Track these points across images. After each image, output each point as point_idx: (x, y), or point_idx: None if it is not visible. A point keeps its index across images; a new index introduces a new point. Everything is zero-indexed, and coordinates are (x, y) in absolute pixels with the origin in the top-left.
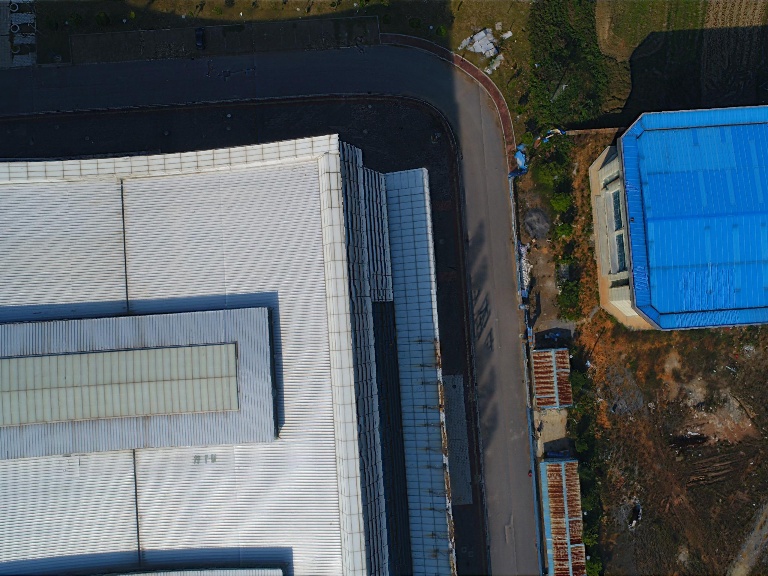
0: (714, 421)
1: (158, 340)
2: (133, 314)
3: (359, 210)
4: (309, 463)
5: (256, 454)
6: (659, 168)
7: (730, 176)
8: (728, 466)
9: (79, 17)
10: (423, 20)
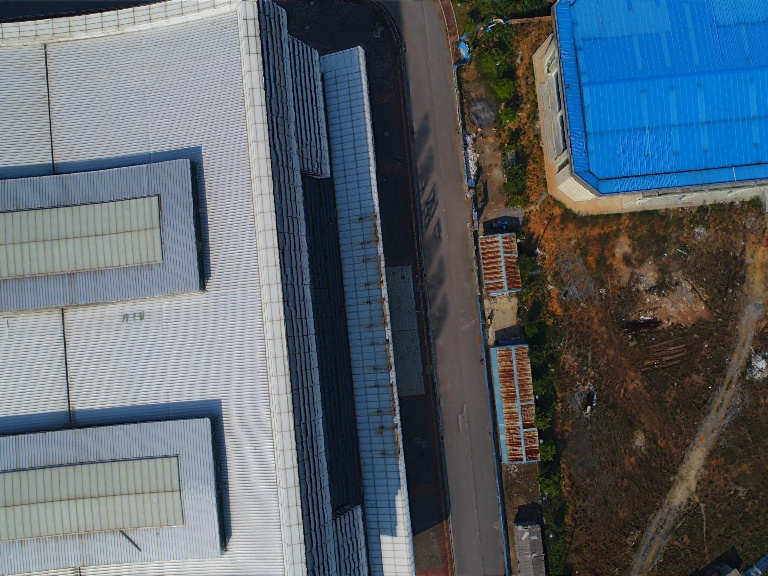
0: (667, 305)
1: (82, 197)
2: None
3: (283, 67)
4: (236, 314)
5: (184, 309)
6: (593, 34)
7: (665, 39)
8: (682, 349)
9: None
10: None
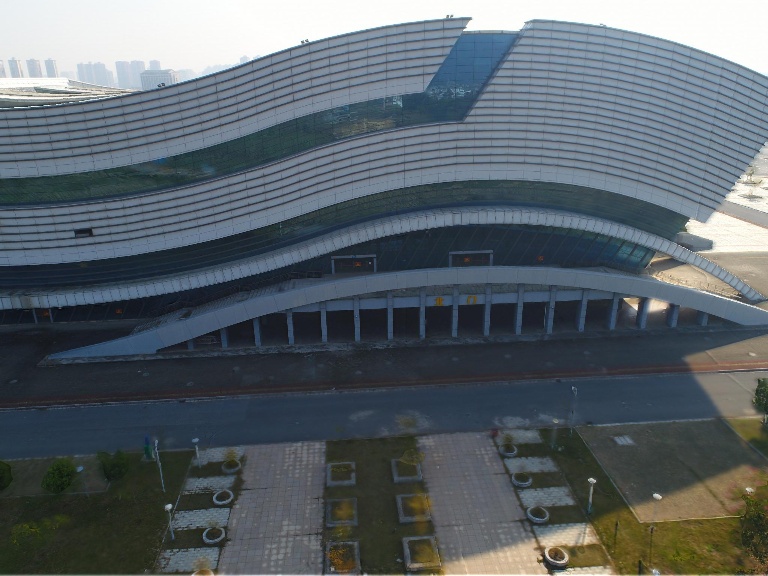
0: None
1: None
2: None
3: None
4: None
5: None
6: None
7: None
8: None
9: (45, 479)
10: None
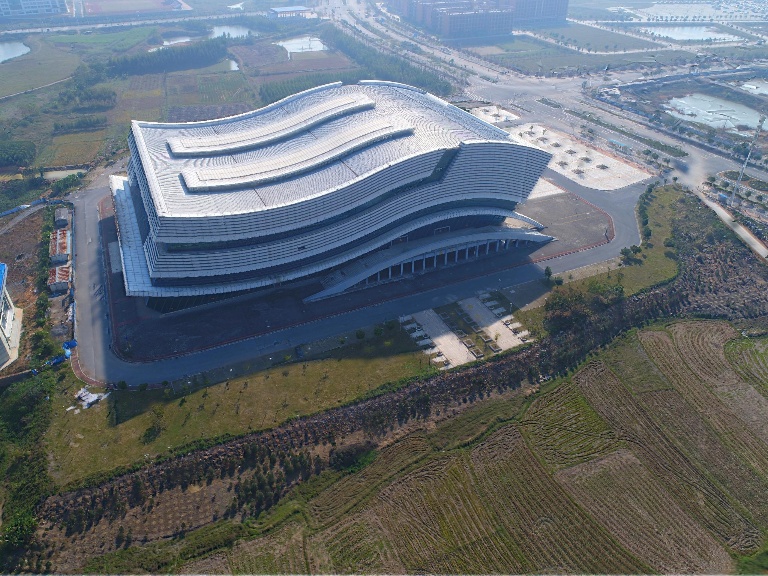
0: None
1: (234, 179)
2: (251, 187)
3: None
4: None
5: None
6: None
7: None
8: None
9: (376, 332)
10: (139, 400)
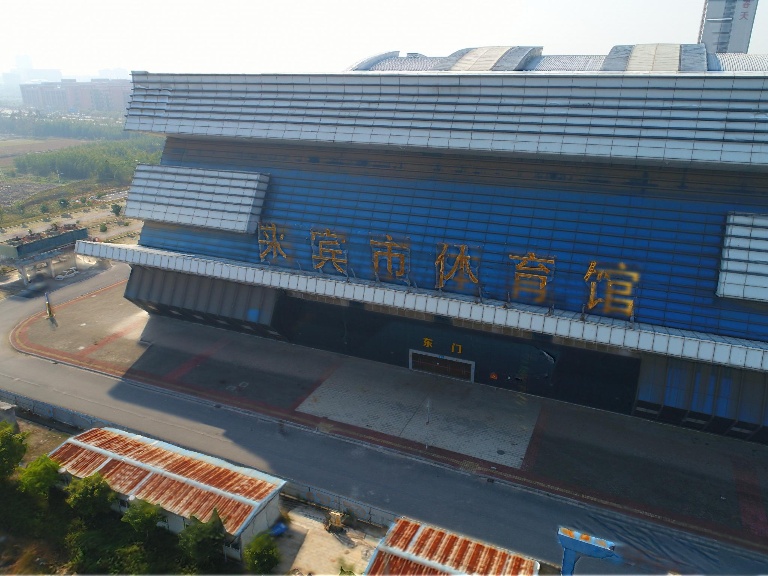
0: None
1: None
2: None
3: None
4: None
5: None
6: None
7: None
8: None
9: None
10: None
